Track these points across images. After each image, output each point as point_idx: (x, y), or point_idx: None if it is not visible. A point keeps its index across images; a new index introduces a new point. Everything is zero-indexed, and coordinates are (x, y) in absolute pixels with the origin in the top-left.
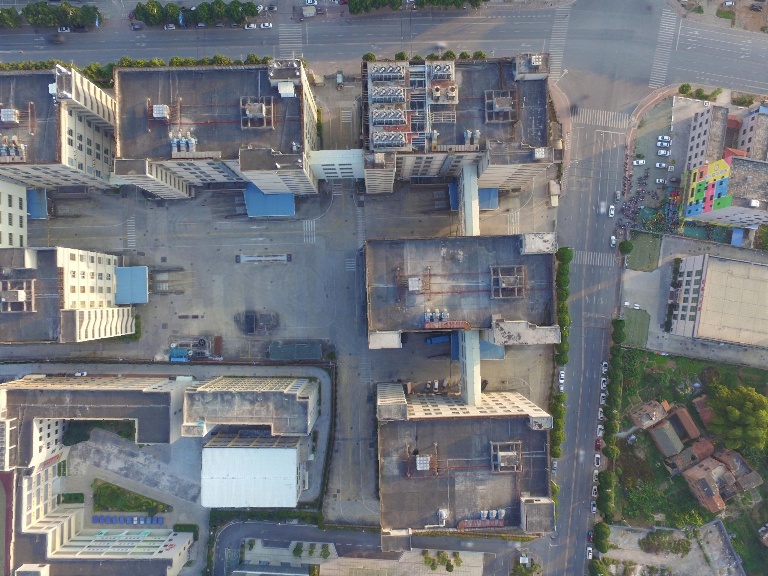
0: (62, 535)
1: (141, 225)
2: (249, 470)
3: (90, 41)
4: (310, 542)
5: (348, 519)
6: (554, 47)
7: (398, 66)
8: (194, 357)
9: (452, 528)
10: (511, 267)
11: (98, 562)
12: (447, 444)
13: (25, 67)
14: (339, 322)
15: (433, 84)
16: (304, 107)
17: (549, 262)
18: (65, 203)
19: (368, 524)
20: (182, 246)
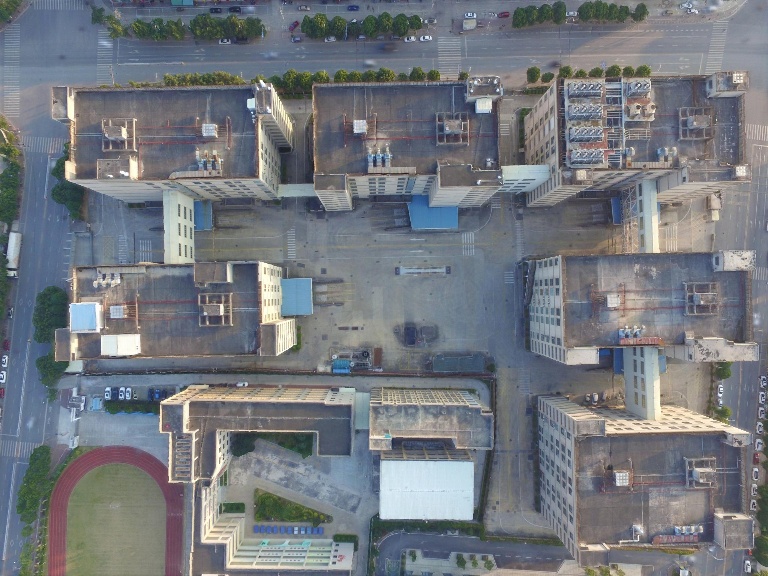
0: (233, 545)
1: (301, 237)
2: (427, 483)
3: (250, 53)
4: (470, 553)
5: (507, 531)
6: (712, 61)
7: (599, 83)
8: (355, 368)
9: (646, 543)
10: (705, 284)
11: (276, 573)
12: (641, 460)
13: (192, 79)
14: (498, 334)
15: (629, 101)
16: (497, 123)
17: (742, 279)
18: (225, 214)
19: (527, 536)
20: (342, 258)
